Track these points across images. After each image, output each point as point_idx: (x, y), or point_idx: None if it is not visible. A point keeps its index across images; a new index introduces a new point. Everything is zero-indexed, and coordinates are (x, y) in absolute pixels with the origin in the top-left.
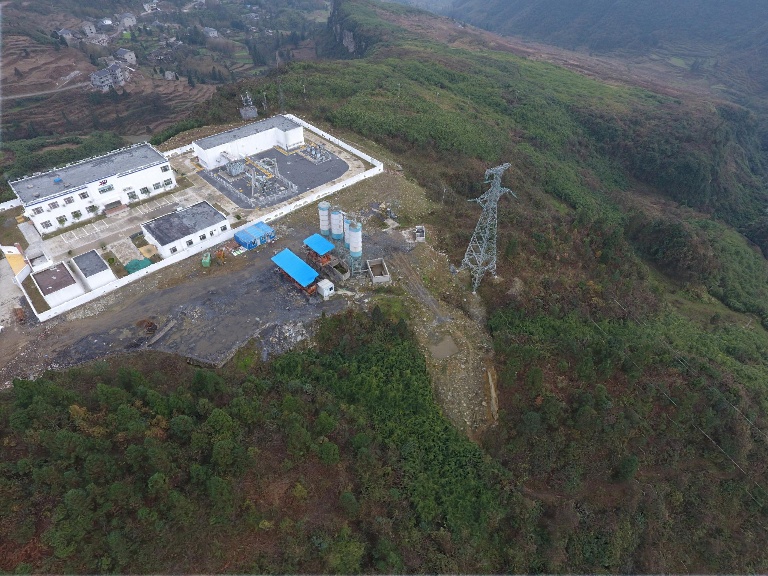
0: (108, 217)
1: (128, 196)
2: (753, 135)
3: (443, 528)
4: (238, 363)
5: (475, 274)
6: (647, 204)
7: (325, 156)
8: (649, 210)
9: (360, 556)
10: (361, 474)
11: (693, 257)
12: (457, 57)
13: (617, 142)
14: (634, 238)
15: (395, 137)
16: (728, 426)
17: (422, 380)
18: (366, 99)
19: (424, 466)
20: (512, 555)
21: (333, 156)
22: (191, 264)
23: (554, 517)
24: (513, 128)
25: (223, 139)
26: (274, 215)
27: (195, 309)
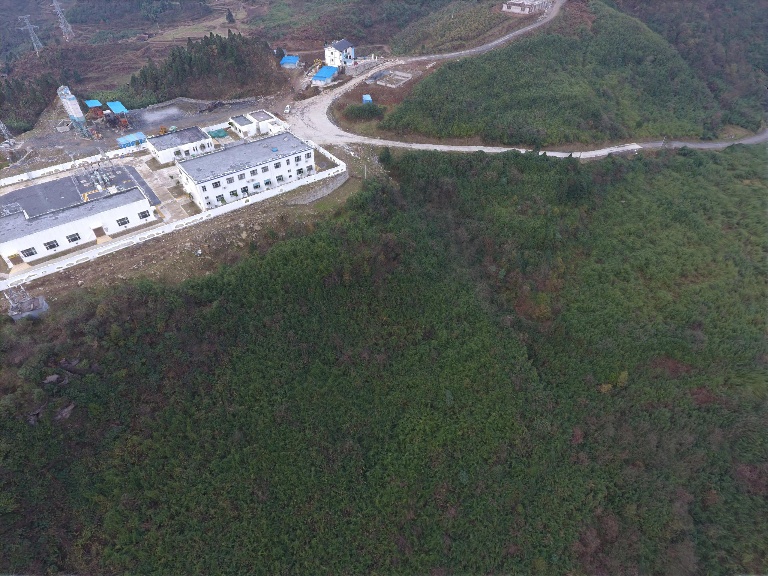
0: None
1: None
2: None
3: None
4: None
5: (5, 127)
6: None
7: None
8: None
9: None
10: None
11: None
12: None
13: None
14: None
15: None
16: None
17: None
18: None
19: None
20: None
21: None
22: None
23: None
24: None
25: (108, 204)
26: (109, 156)
27: (187, 115)
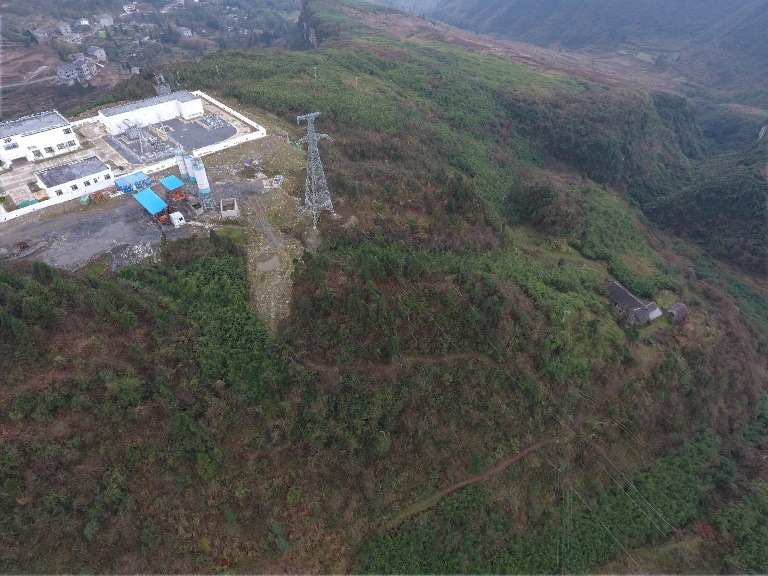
0: (14, 171)
1: (34, 154)
2: (693, 122)
3: (221, 380)
4: (89, 271)
5: (313, 211)
6: (554, 178)
7: (219, 124)
8: (552, 182)
9: (141, 390)
10: (156, 338)
11: (556, 213)
12: (398, 48)
13: (537, 123)
14: (517, 201)
15: (297, 112)
16: (495, 323)
17: (237, 284)
18: (282, 81)
19: (221, 342)
20: (284, 407)
21: (226, 124)
22: (72, 203)
23: (320, 379)
24: (434, 110)
25: (126, 109)
26: (156, 168)
27: (65, 234)
